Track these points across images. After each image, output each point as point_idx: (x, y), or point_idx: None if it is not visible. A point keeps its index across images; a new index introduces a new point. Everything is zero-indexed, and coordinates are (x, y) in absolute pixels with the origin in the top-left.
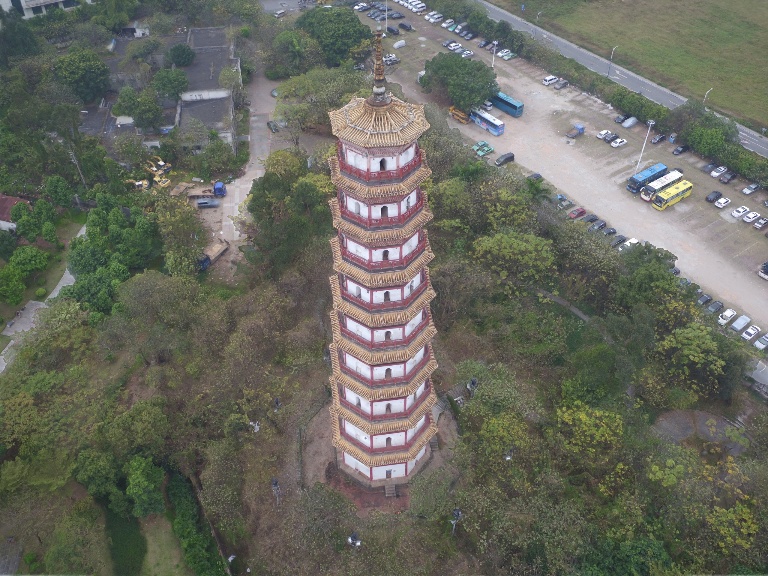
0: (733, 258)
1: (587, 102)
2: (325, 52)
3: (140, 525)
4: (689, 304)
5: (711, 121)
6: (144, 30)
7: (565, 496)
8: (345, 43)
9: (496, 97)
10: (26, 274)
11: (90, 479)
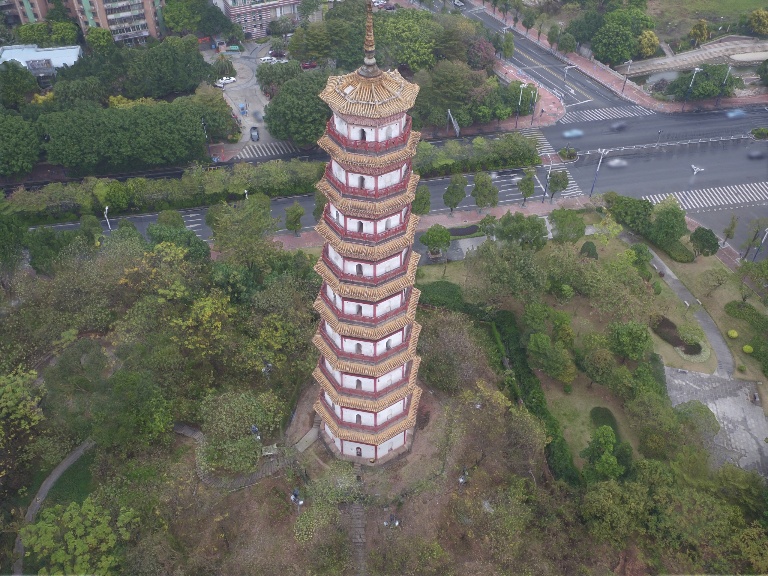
0: None
1: None
2: None
3: None
4: None
5: None
6: None
7: None
8: None
9: None
10: None
11: None
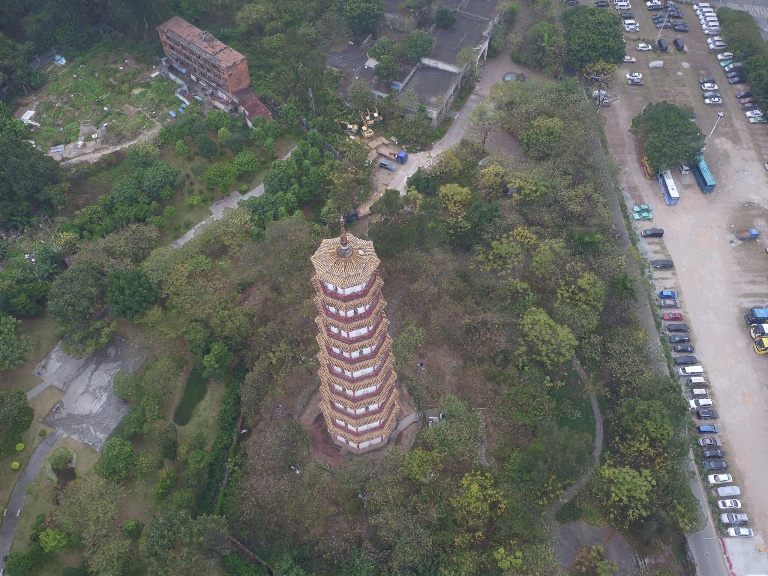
0: None
1: None
2: (569, 55)
3: (209, 381)
4: (670, 452)
5: None
6: None
7: (446, 527)
8: (589, 54)
9: (696, 165)
10: (239, 173)
11: (191, 341)
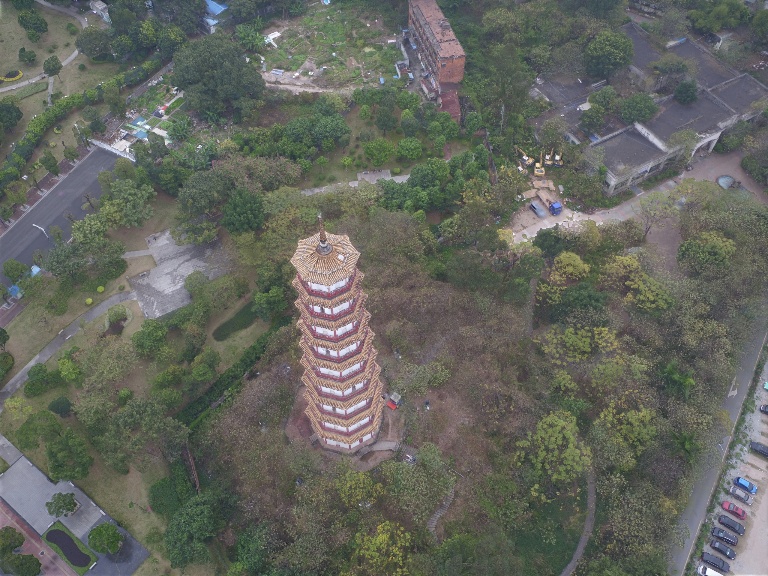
0: None
1: None
2: None
3: None
4: None
5: None
6: None
7: None
8: None
9: None
10: (399, 155)
11: None
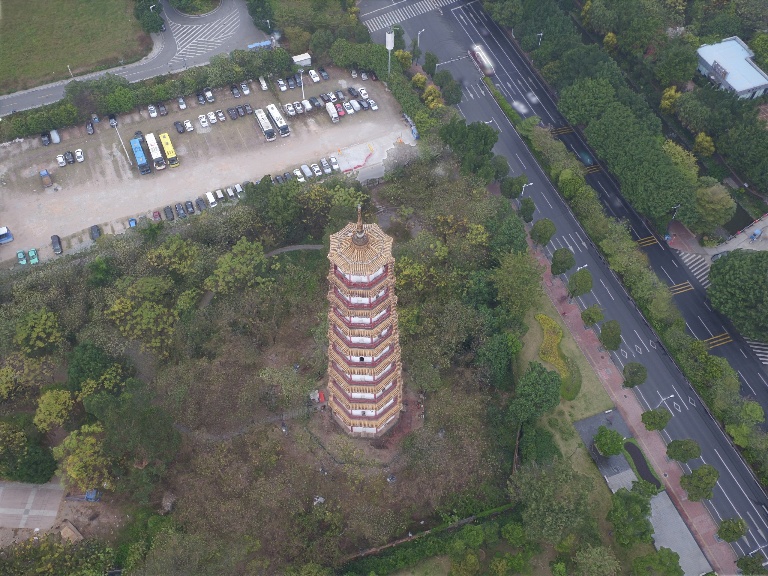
0: (247, 147)
1: (1, 153)
2: None
3: None
4: None
5: (102, 86)
6: None
7: None
8: None
9: None
10: None
11: None
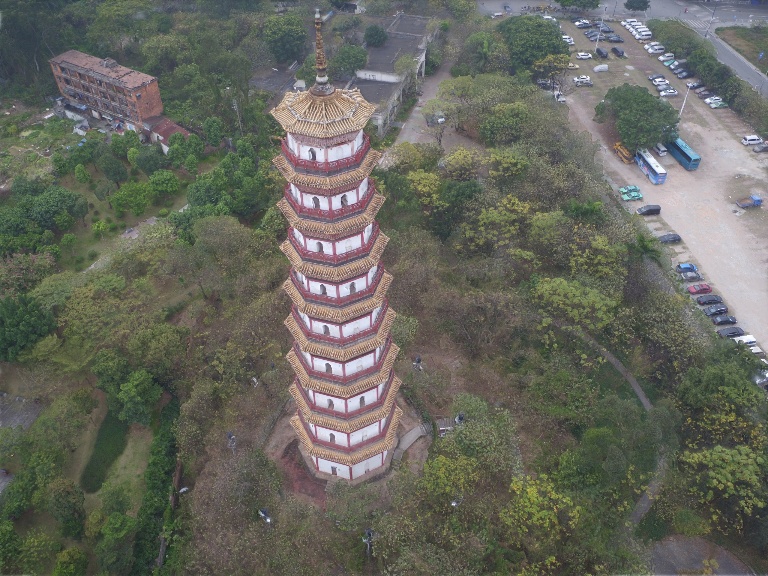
0: None
1: None
2: (512, 60)
3: (129, 429)
4: None
5: None
6: (364, 8)
7: (495, 567)
8: (534, 55)
9: (673, 143)
10: (156, 193)
11: (100, 374)
